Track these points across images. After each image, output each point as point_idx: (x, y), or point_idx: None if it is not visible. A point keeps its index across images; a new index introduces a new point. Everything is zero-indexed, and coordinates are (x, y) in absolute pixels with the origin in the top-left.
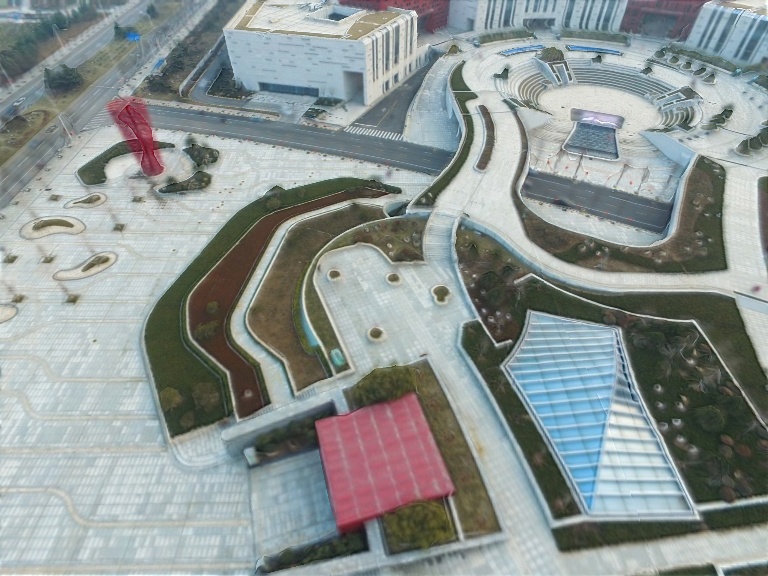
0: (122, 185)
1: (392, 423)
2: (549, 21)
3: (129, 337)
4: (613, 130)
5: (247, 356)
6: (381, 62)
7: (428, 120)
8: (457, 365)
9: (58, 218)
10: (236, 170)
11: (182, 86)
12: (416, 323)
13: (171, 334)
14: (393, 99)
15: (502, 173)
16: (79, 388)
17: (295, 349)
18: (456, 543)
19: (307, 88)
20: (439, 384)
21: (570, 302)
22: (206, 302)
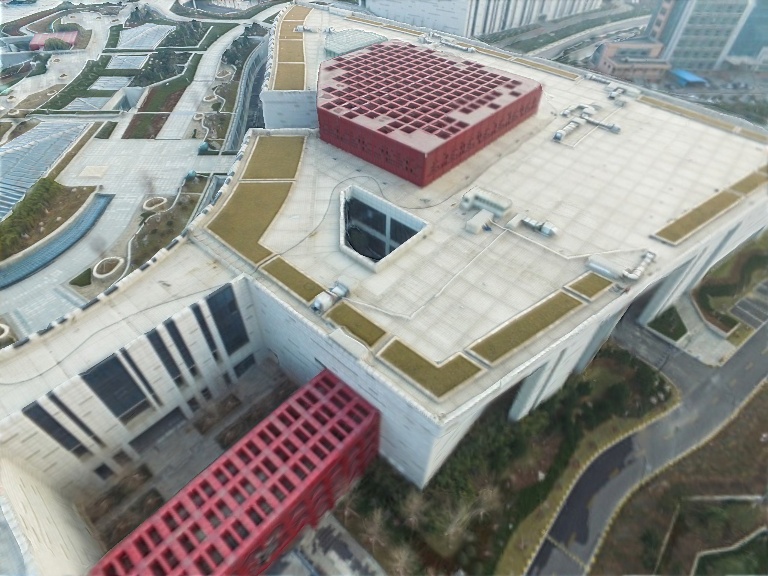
0: None
1: (63, 34)
2: None
3: None
4: None
5: (23, 33)
6: None
7: None
8: (104, 32)
9: None
10: (52, 0)
11: None
12: (98, 26)
13: None
14: None
15: None
16: None
17: None
18: (68, 50)
19: None
20: None
21: None
22: None
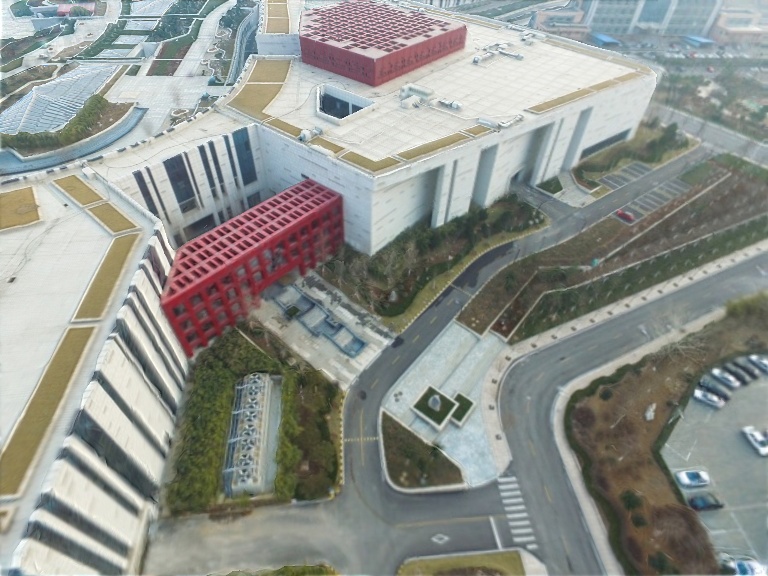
0: None
1: None
2: None
3: (4, 8)
4: None
5: None
6: None
7: None
8: (117, 4)
9: None
10: None
11: None
12: None
13: (20, 5)
14: None
15: None
16: None
17: (63, 3)
18: (90, 17)
19: None
20: (106, 4)
21: None
22: None
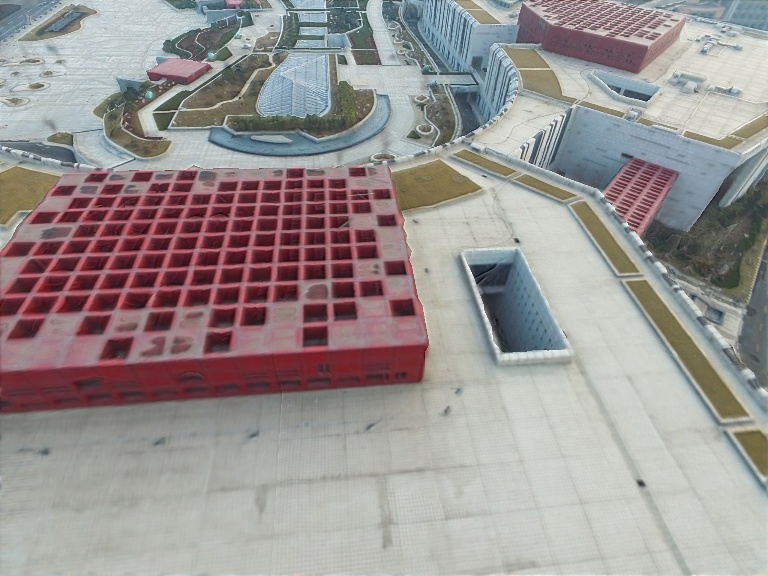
0: None
1: None
2: None
3: (159, 1)
4: None
5: None
6: None
7: None
8: None
9: None
10: None
11: None
12: None
13: None
14: None
15: None
16: (145, 6)
17: None
18: (260, 9)
19: None
20: None
21: None
22: None
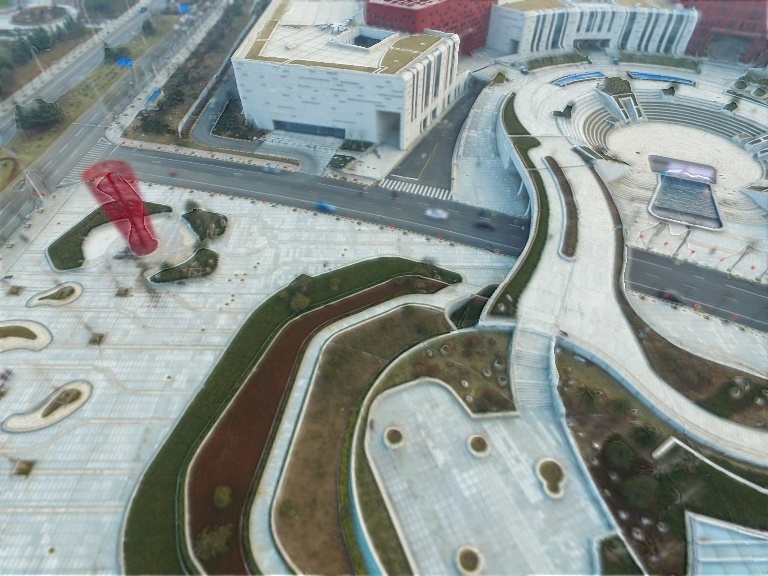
0: (104, 269)
1: None
2: (603, 42)
3: (101, 542)
4: (707, 186)
5: None
6: (420, 98)
7: (479, 170)
8: None
9: (17, 324)
10: (249, 245)
11: (182, 123)
12: (524, 535)
13: (162, 542)
14: (433, 141)
15: (597, 262)
16: None
17: None
18: None
19: (331, 128)
20: None
21: (743, 496)
22: (213, 483)
